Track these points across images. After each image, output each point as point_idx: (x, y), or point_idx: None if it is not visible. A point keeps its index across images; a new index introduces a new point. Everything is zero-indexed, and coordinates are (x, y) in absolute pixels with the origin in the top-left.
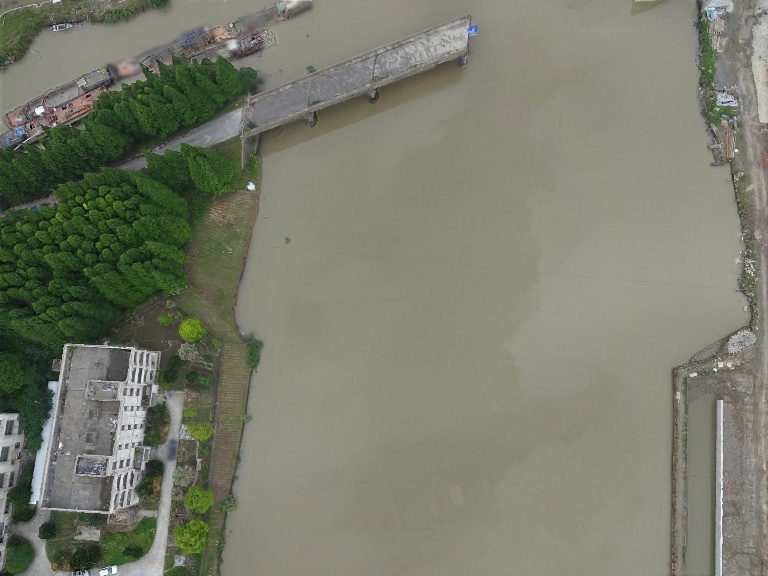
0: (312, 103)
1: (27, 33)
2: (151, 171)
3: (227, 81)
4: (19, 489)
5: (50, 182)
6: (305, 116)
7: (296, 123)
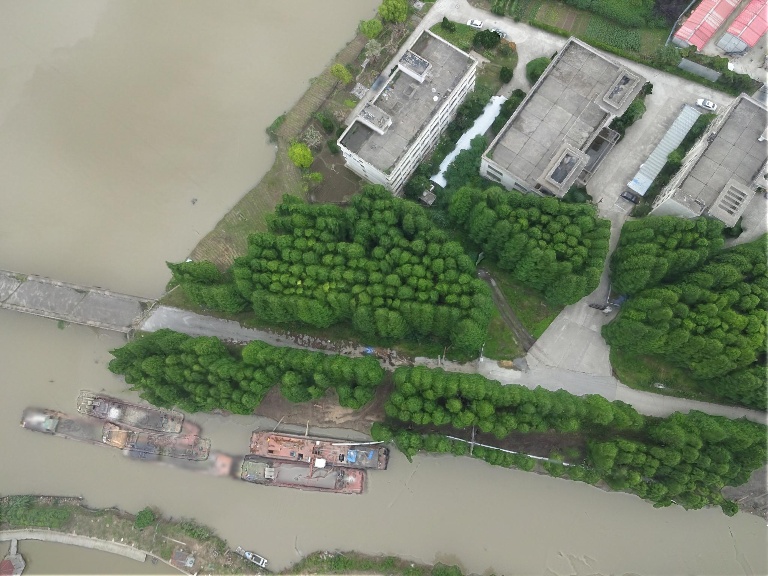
0: (83, 293)
1: (292, 575)
2: (237, 296)
3: None
4: (505, 107)
5: None
6: None
7: None
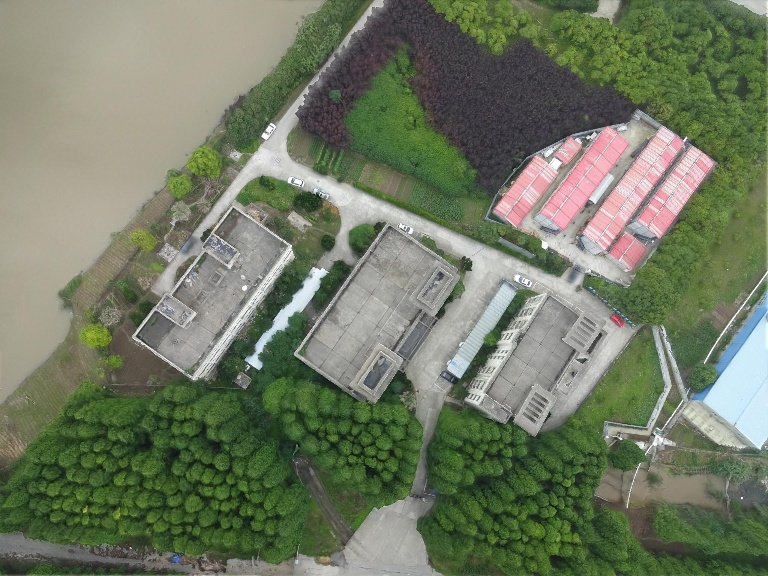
0: None
1: None
2: None
3: None
4: (324, 285)
5: (134, 575)
6: None
7: None
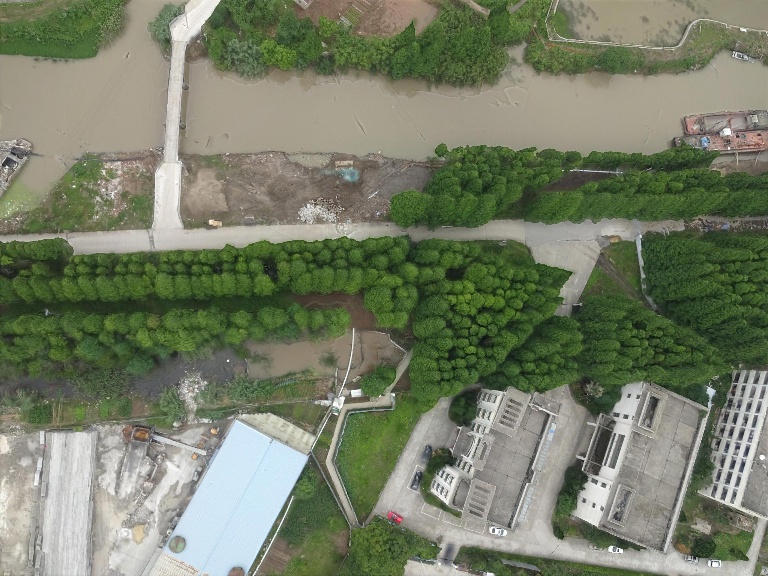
0: None
1: (716, 49)
2: None
3: None
4: None
5: (757, 212)
6: None
7: None
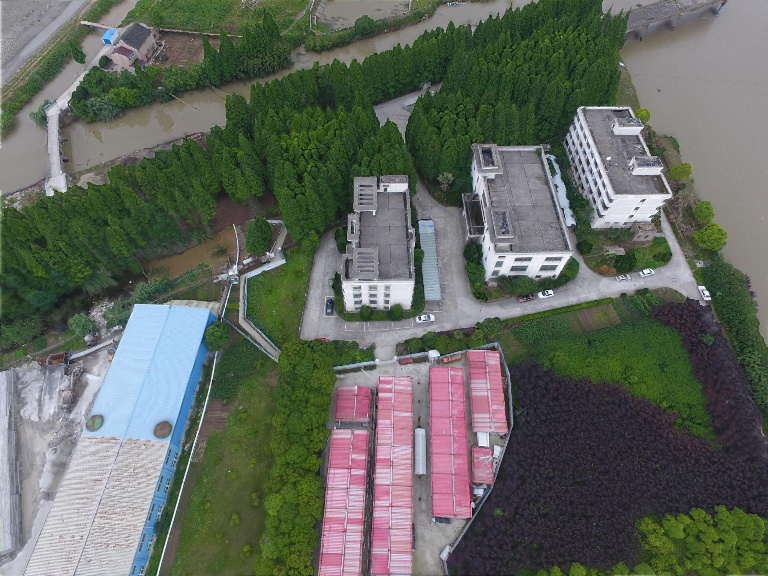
0: (649, 19)
1: (434, 5)
2: None
3: (601, 2)
4: None
5: None
6: (646, 26)
7: (634, 36)
